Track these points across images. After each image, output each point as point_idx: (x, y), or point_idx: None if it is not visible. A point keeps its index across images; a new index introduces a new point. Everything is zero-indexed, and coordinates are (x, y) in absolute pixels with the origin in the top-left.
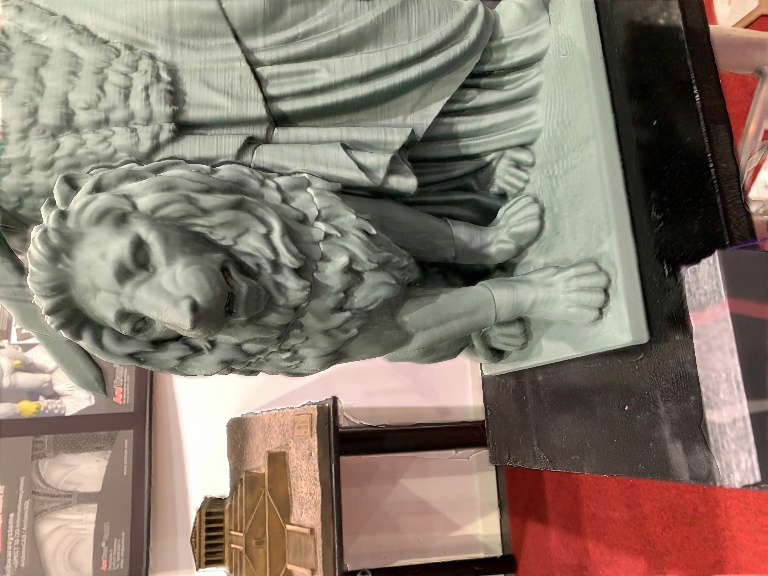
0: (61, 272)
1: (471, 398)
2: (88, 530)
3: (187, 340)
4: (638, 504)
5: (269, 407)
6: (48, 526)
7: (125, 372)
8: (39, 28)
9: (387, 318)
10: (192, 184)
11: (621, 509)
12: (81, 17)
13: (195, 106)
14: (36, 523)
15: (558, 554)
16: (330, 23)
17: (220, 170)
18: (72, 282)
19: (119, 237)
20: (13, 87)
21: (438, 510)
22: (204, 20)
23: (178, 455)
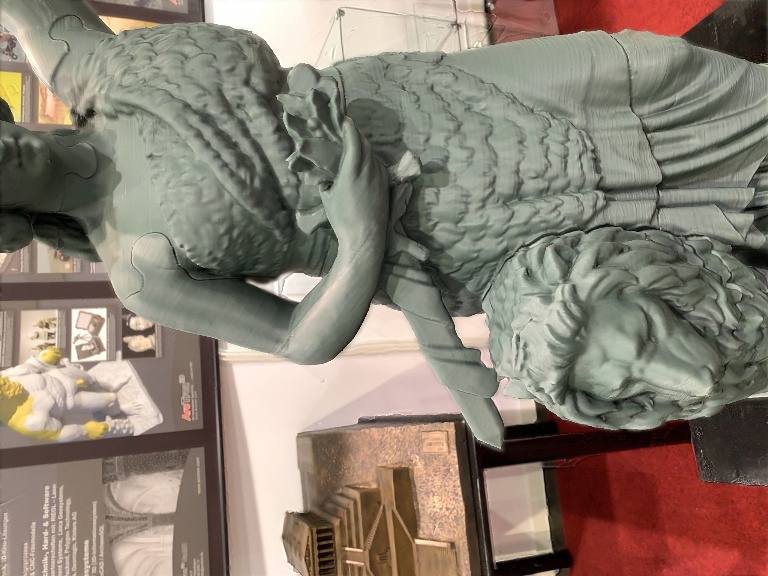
0: (577, 344)
1: (519, 402)
2: (166, 552)
3: (632, 398)
4: (730, 501)
5: (331, 418)
6: (125, 551)
7: (192, 388)
8: (478, 96)
9: (761, 367)
10: (666, 256)
11: (709, 506)
12: (509, 85)
13: (609, 173)
14: (113, 549)
15: (627, 548)
16: (699, 92)
17: (650, 236)
18: (582, 353)
19: (627, 310)
20: (472, 157)
21: (493, 511)
22: (614, 90)
23: (246, 470)
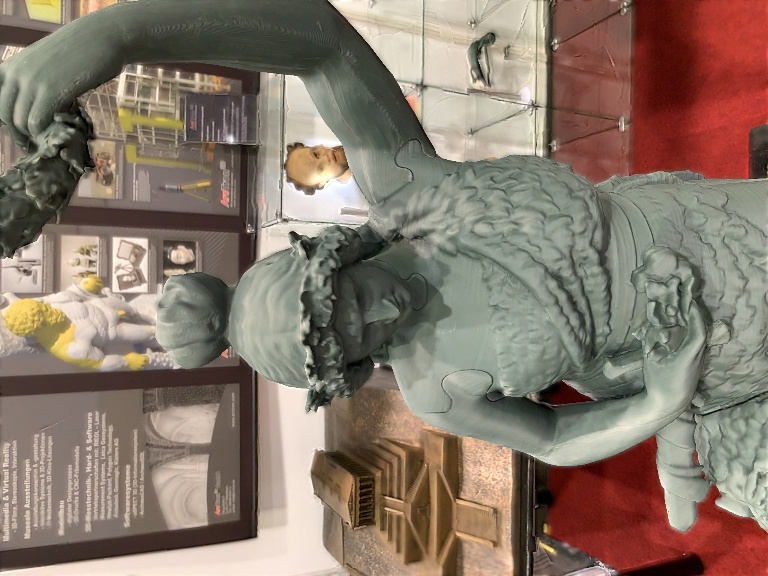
0: None
1: None
2: (201, 479)
3: None
4: None
5: None
6: (164, 476)
7: None
8: (761, 252)
9: None
10: None
11: None
12: None
13: None
14: (153, 474)
15: (609, 500)
16: None
17: None
18: None
19: None
20: (754, 315)
21: None
22: None
23: (274, 405)
